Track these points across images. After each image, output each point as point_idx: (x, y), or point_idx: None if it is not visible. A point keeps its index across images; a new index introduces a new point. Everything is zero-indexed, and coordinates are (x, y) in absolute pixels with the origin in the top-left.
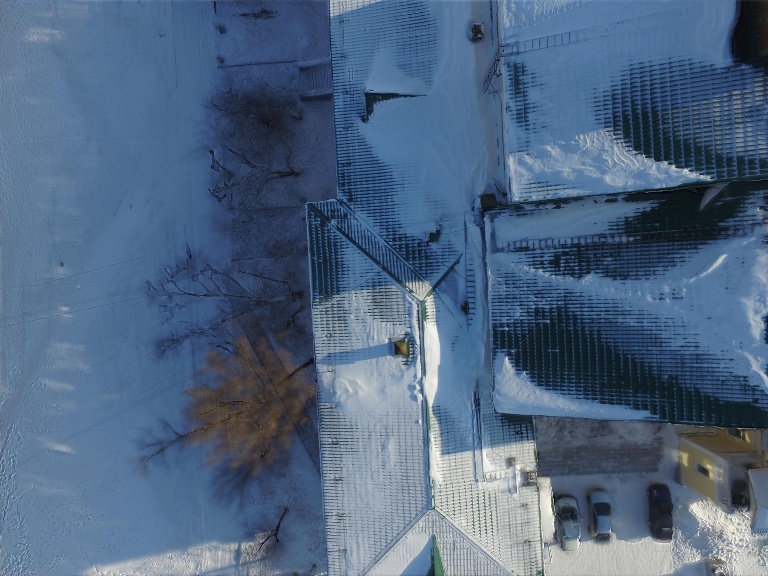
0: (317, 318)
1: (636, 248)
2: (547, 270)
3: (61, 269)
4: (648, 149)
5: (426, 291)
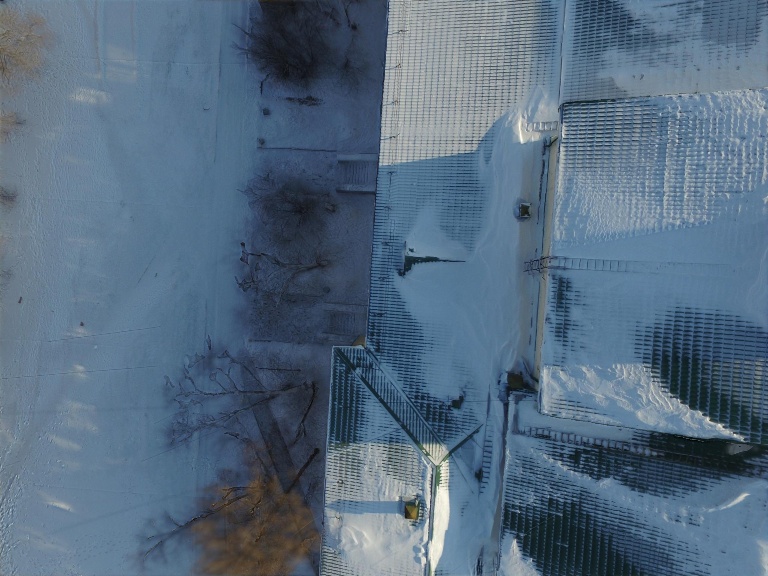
0: (331, 462)
1: (658, 464)
2: (566, 464)
3: (80, 328)
4: (684, 395)
5: (442, 455)
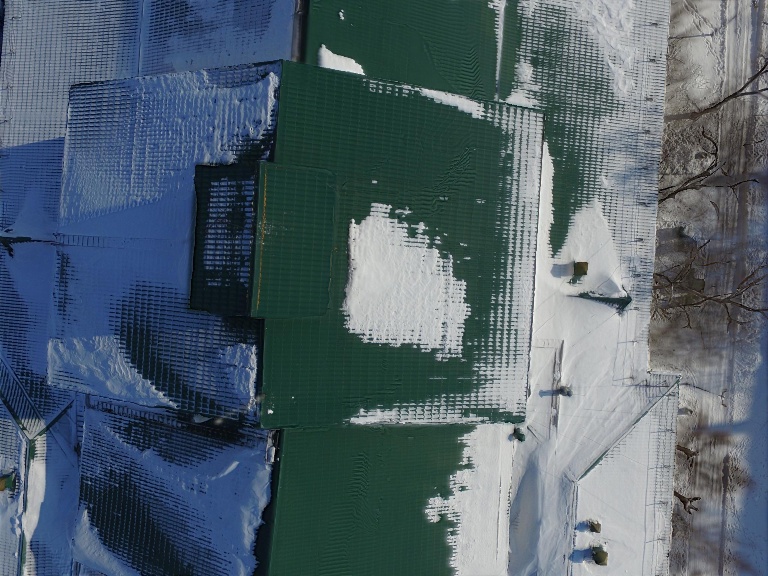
0: None
1: (183, 435)
2: (122, 436)
3: None
4: (140, 365)
5: (39, 430)
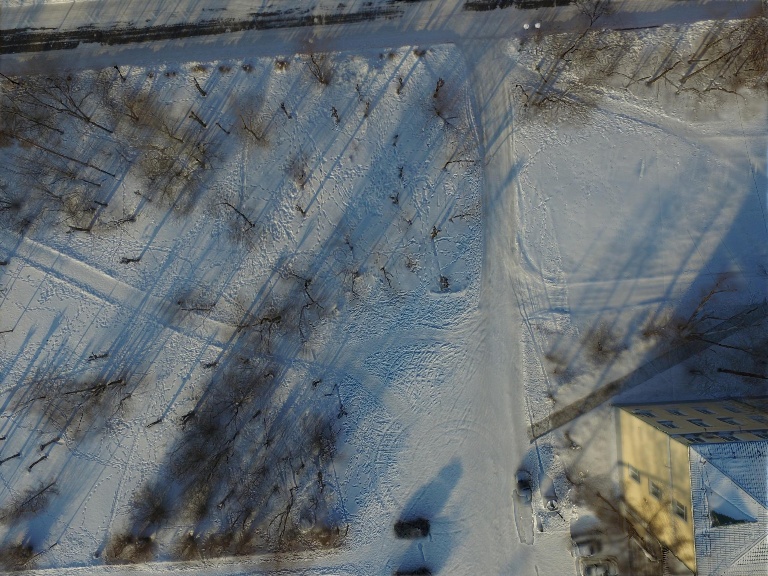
0: None
1: None
2: None
3: None
4: None
5: None
